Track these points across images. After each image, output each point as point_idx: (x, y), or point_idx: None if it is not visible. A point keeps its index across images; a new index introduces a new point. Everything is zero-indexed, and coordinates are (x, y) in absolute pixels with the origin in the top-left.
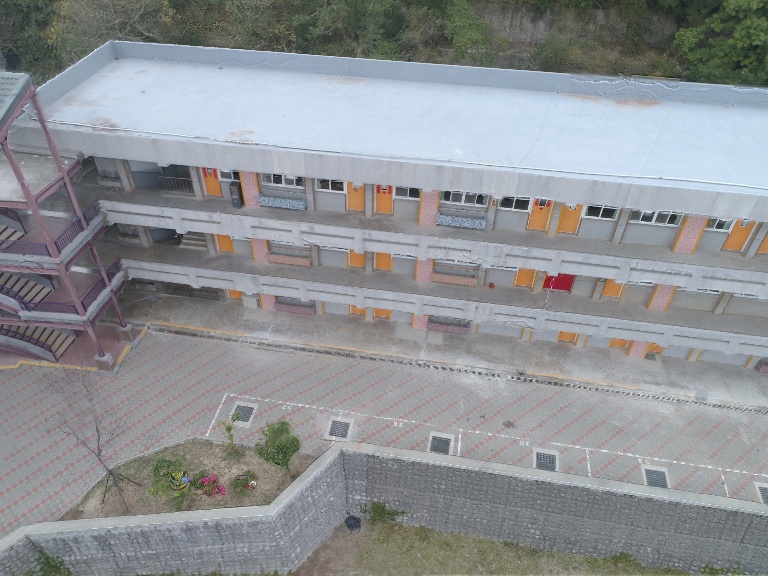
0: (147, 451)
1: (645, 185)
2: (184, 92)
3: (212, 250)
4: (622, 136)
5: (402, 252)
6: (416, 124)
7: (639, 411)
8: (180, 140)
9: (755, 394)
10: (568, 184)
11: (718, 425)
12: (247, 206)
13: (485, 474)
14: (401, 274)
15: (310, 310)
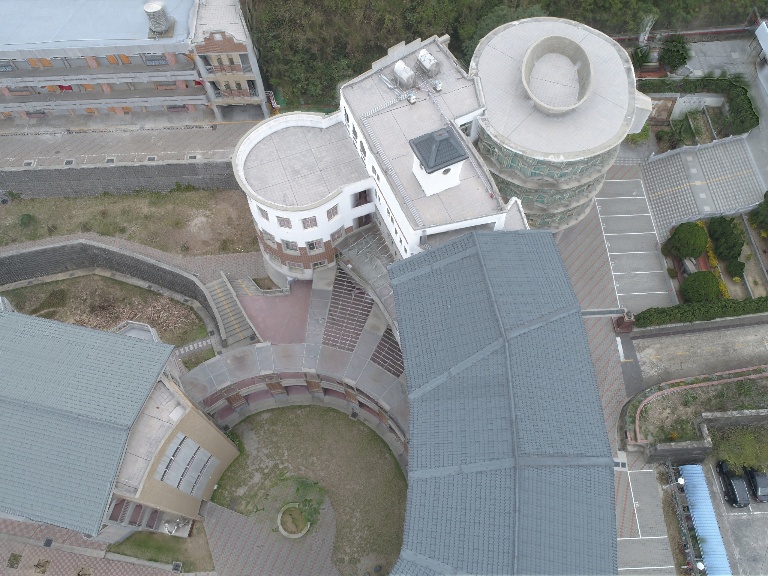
0: None
1: (37, 50)
2: None
3: None
4: (55, 19)
5: None
6: None
7: (114, 137)
8: None
9: (165, 122)
10: (12, 53)
11: (144, 137)
12: None
13: (37, 171)
14: None
15: None
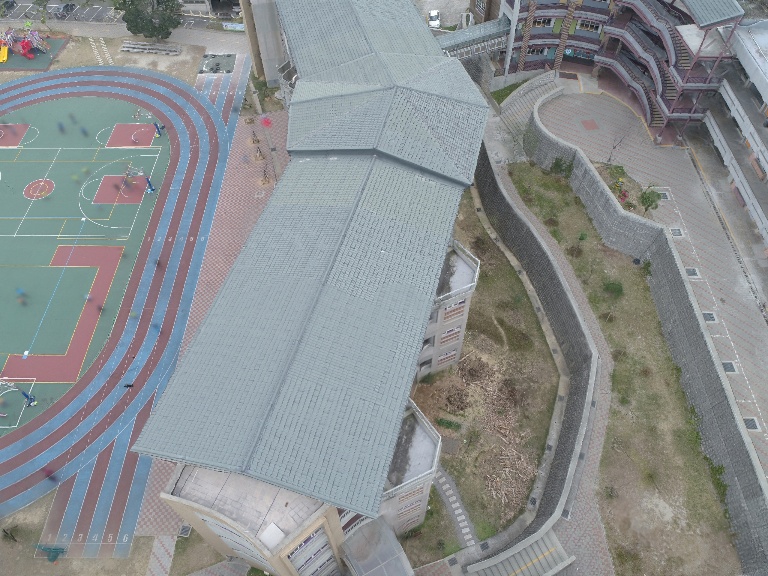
0: None
1: None
2: None
3: (743, 140)
4: None
5: None
6: None
7: None
8: (763, 75)
9: None
10: None
11: None
12: None
13: (683, 284)
14: None
15: (742, 202)
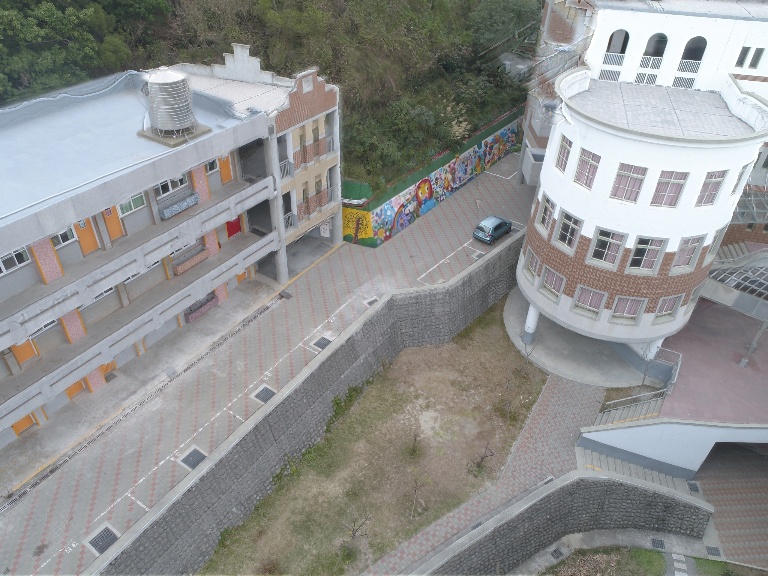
0: None
1: None
2: None
3: None
4: None
5: None
6: None
7: (139, 425)
8: None
9: (201, 340)
10: None
11: (198, 382)
12: None
13: None
14: None
15: None
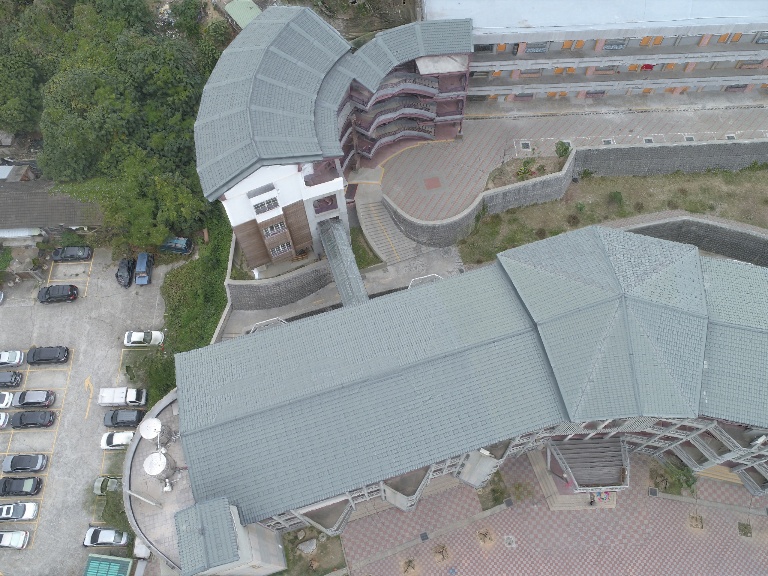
0: (498, 166)
1: (696, 26)
2: (477, 0)
3: (490, 76)
4: None
5: (594, 65)
6: (592, 4)
7: (680, 117)
8: (515, 33)
9: (725, 101)
10: (668, 29)
11: (711, 117)
12: (518, 54)
13: (631, 148)
14: (578, 74)
15: (531, 98)
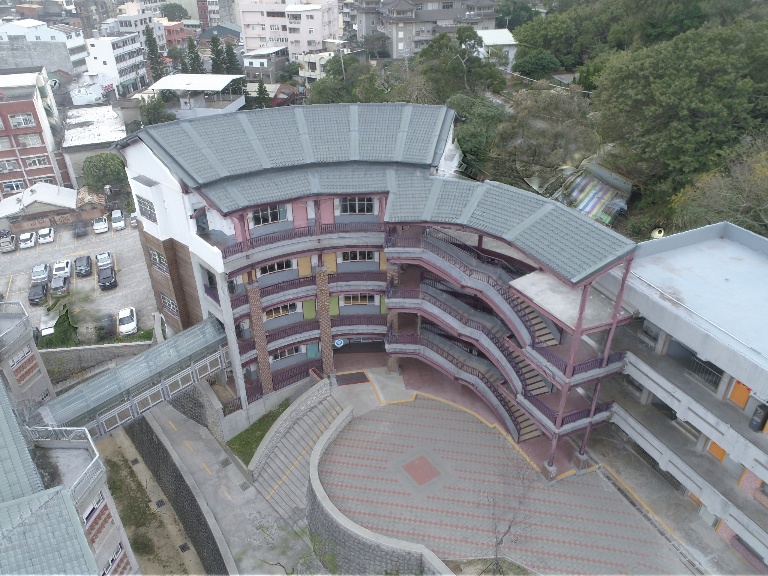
0: (532, 568)
1: None
2: None
3: (701, 445)
4: None
5: None
6: None
7: None
8: (732, 348)
9: None
10: None
11: None
12: (764, 434)
13: None
14: None
15: None
